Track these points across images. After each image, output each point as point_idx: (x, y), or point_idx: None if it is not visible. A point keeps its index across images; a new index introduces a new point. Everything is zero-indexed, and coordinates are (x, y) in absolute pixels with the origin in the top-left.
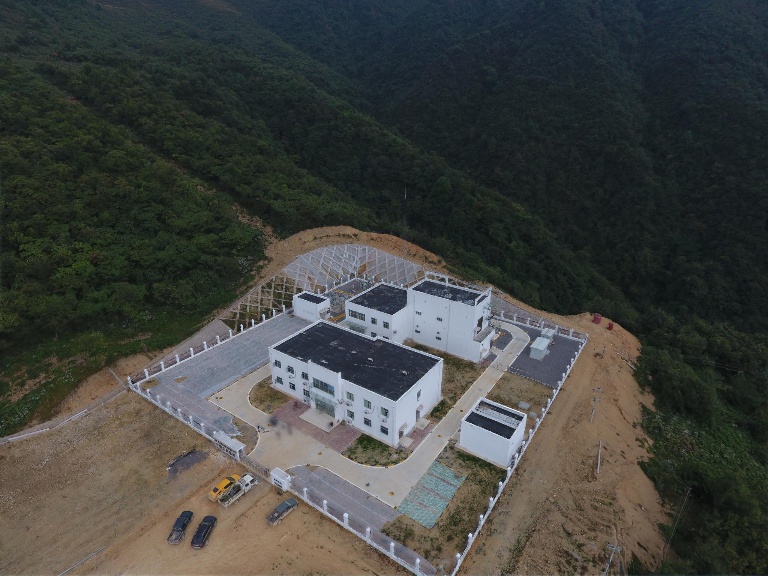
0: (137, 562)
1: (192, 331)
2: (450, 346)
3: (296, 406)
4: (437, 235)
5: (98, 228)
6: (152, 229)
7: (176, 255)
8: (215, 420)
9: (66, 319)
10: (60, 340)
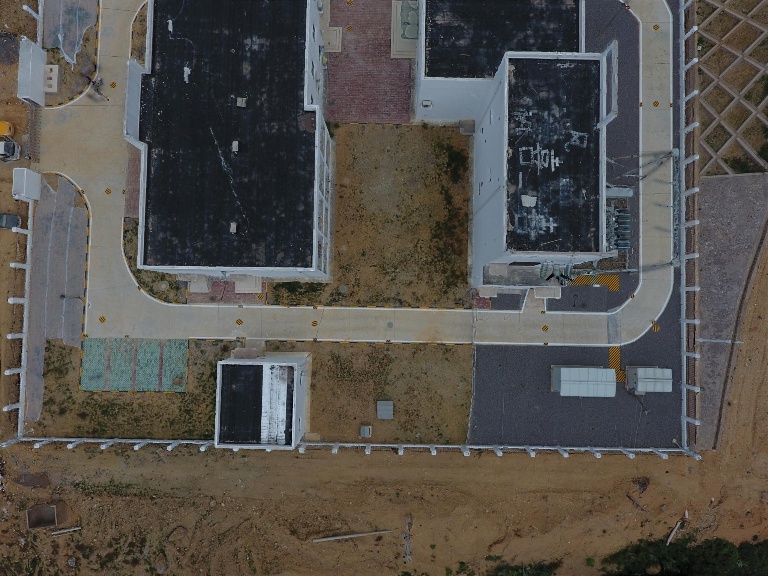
0: None
1: None
2: (477, 220)
3: None
4: None
5: None
6: None
7: None
8: (72, 6)
9: None
10: None
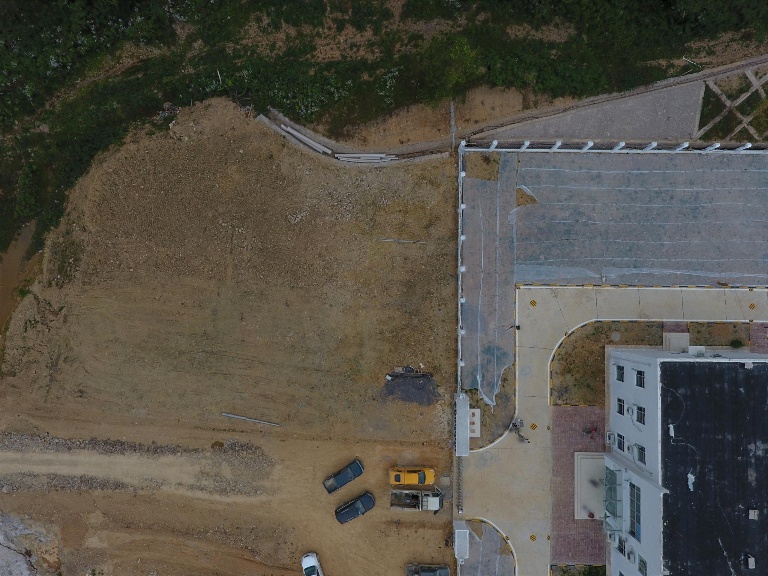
0: (292, 466)
1: (636, 80)
2: None
3: (591, 431)
4: None
5: None
6: None
7: None
8: (490, 346)
9: None
10: None
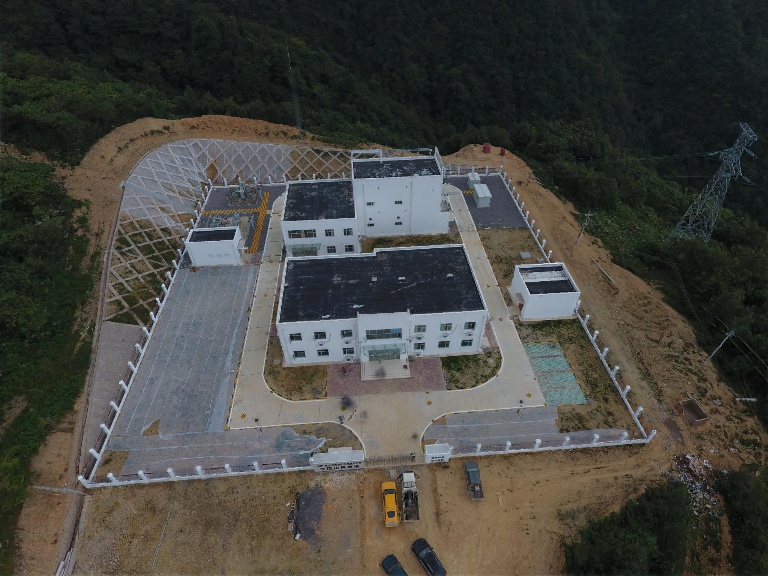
0: None
1: (84, 358)
2: (414, 227)
3: (345, 371)
4: None
5: None
6: None
7: None
8: (275, 445)
9: None
10: None
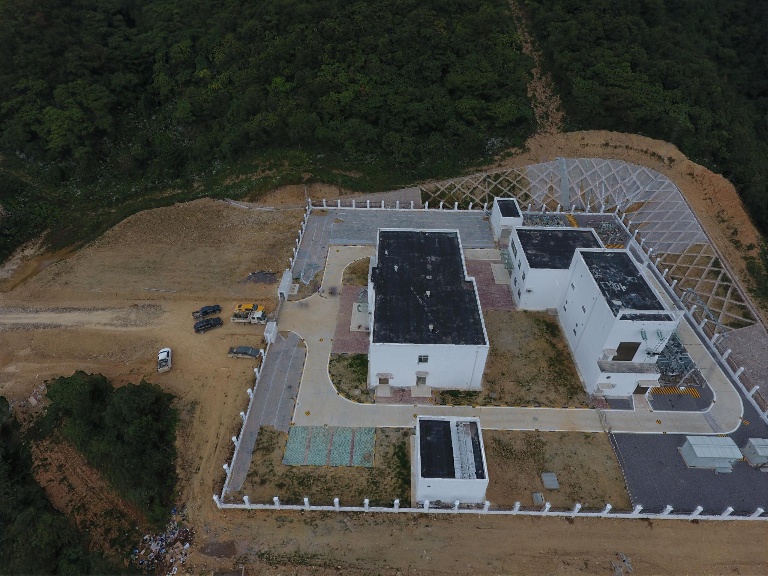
0: (176, 313)
1: (390, 187)
2: (579, 350)
3: (364, 293)
4: None
5: (385, 65)
6: (430, 79)
7: (425, 111)
8: (311, 263)
9: (298, 134)
10: (301, 150)
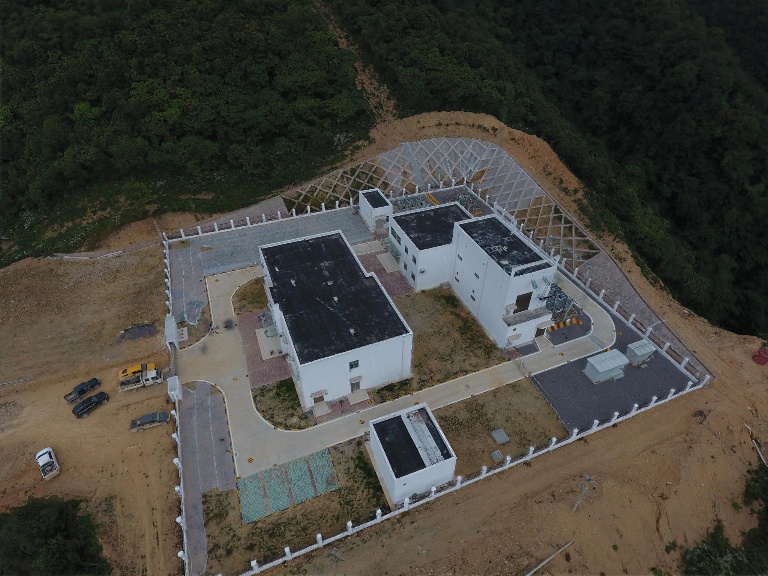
0: (40, 403)
1: (249, 202)
2: (481, 313)
3: None
4: (641, 149)
5: (206, 75)
6: (258, 84)
7: (263, 117)
8: (191, 301)
9: (129, 164)
10: (135, 181)
